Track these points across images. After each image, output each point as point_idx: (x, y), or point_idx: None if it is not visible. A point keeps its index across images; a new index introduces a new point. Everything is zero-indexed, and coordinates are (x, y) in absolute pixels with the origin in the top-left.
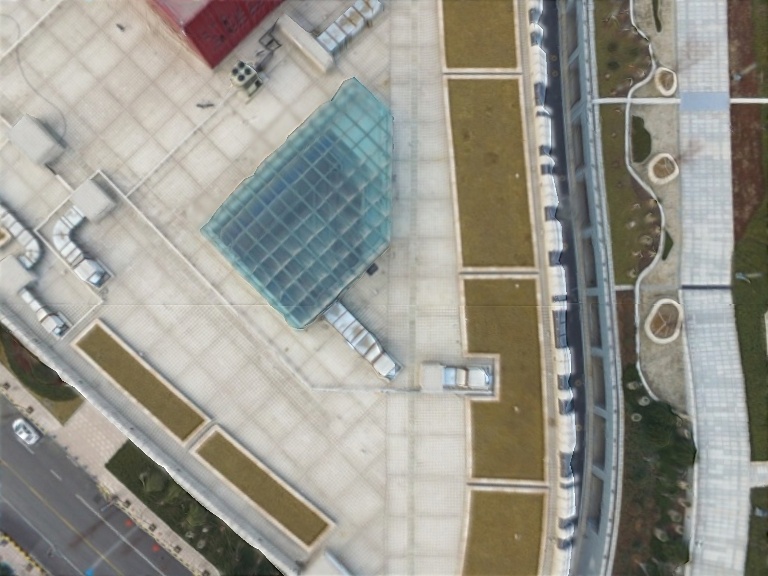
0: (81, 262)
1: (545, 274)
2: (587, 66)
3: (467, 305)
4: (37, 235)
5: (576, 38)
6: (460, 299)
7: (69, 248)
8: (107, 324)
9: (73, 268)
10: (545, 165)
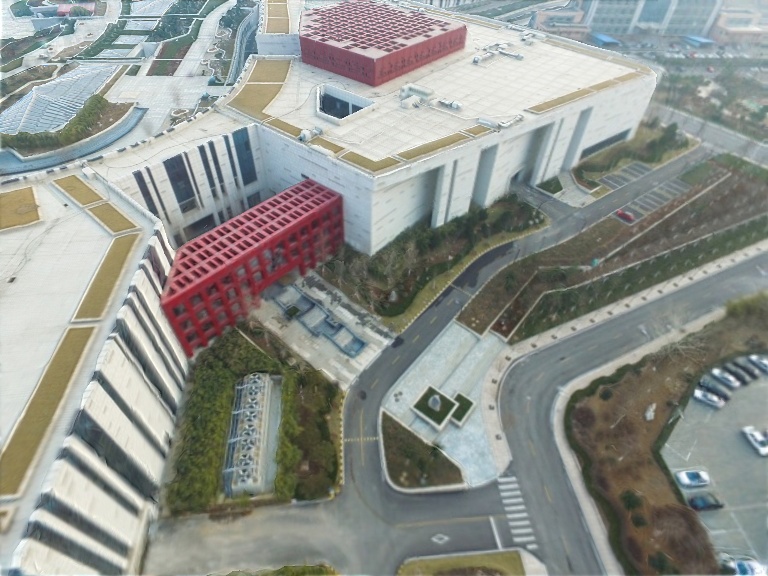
0: (385, 1)
1: (265, 3)
2: (234, 65)
3: (286, 1)
4: (400, 6)
5: (235, 75)
6: (288, 2)
7: (390, 4)
8: (379, 1)
9: (387, 1)
10: (263, 8)
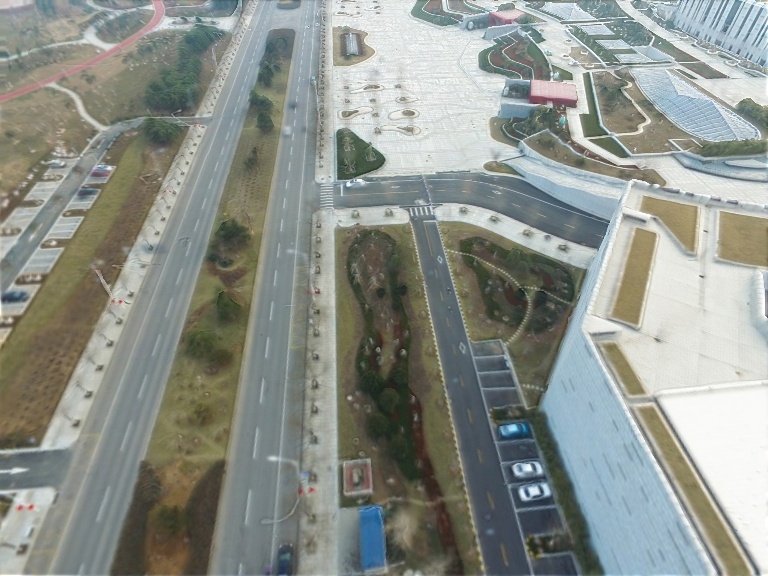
0: None
1: None
2: (761, 66)
3: None
4: None
5: None
6: None
7: None
8: None
9: None
10: None
